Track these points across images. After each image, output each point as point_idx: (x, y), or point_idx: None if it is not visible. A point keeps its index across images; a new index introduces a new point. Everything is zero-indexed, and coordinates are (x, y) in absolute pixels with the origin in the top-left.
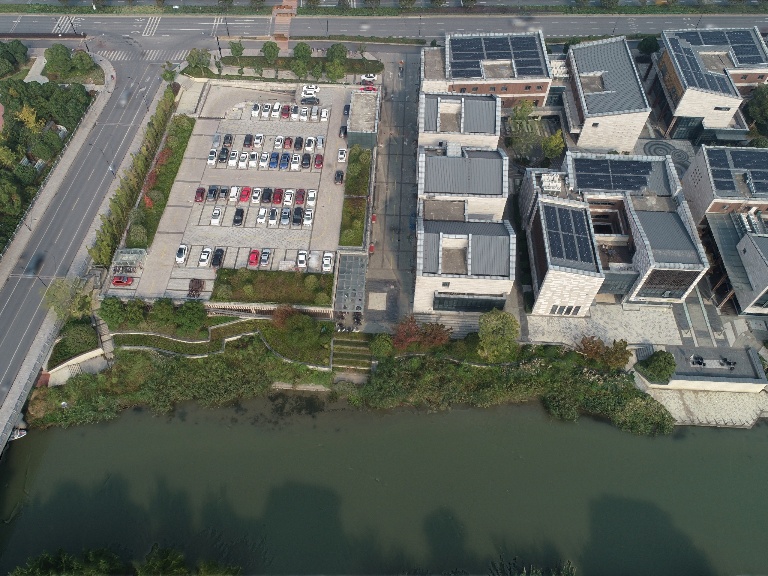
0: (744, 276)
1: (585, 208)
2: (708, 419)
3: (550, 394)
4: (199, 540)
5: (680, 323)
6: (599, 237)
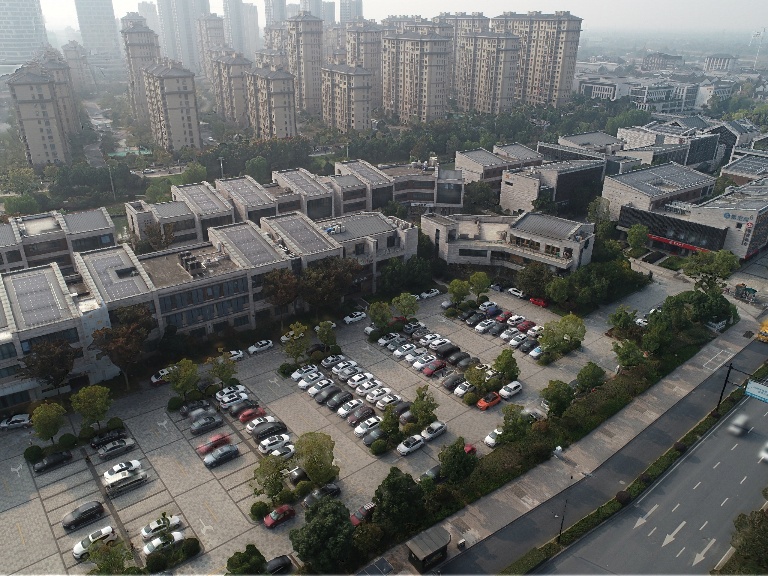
0: None
1: None
2: None
3: None
4: None
5: None
6: None
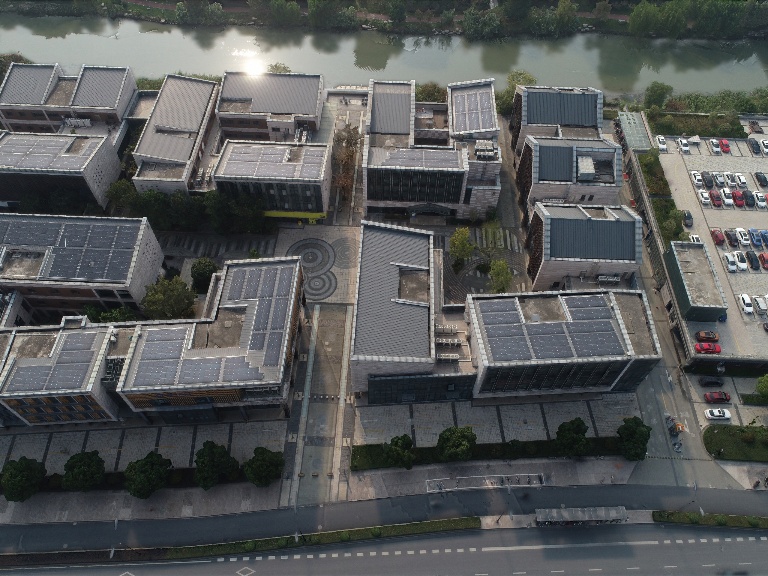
0: (325, 111)
1: None
2: (367, 89)
3: None
4: (663, 50)
5: None
6: None
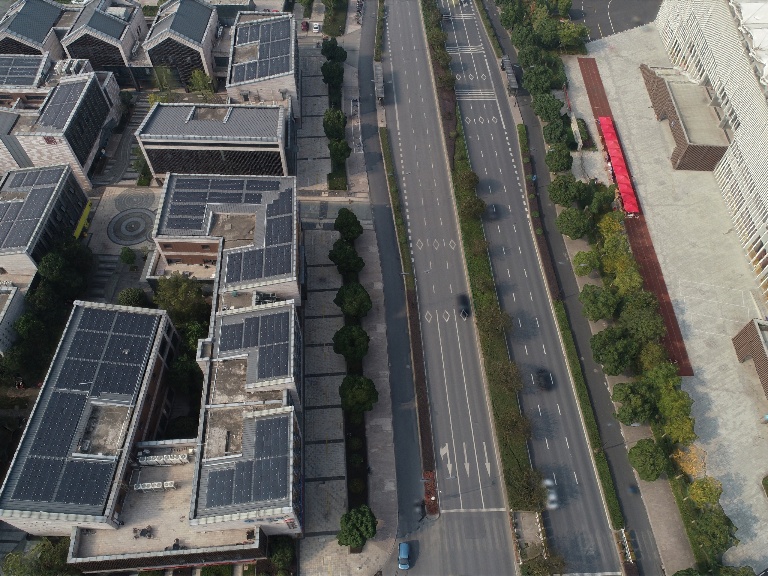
0: None
1: None
2: None
3: None
4: None
5: None
6: None
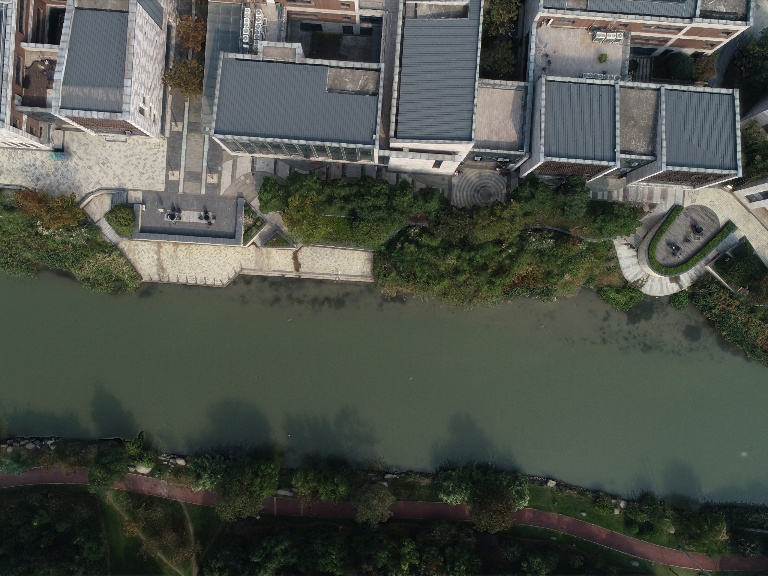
0: None
1: (7, 3)
2: (179, 277)
3: (3, 248)
4: None
5: (170, 160)
6: (38, 48)
